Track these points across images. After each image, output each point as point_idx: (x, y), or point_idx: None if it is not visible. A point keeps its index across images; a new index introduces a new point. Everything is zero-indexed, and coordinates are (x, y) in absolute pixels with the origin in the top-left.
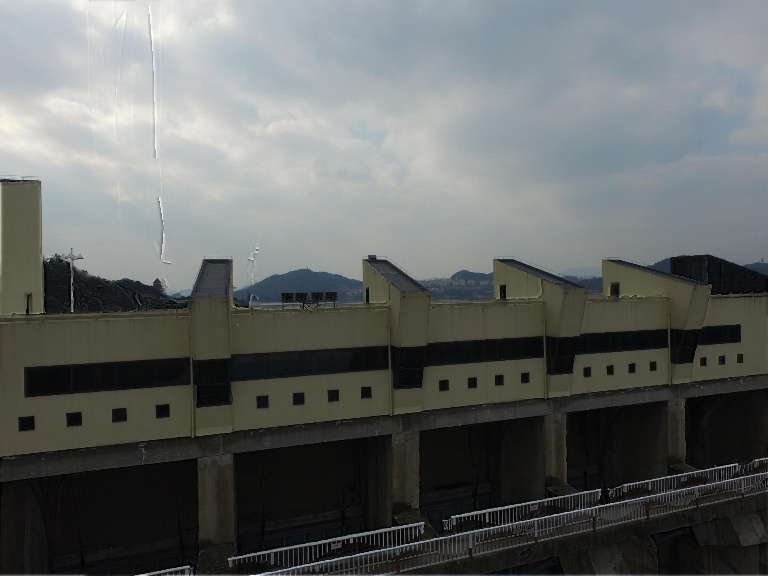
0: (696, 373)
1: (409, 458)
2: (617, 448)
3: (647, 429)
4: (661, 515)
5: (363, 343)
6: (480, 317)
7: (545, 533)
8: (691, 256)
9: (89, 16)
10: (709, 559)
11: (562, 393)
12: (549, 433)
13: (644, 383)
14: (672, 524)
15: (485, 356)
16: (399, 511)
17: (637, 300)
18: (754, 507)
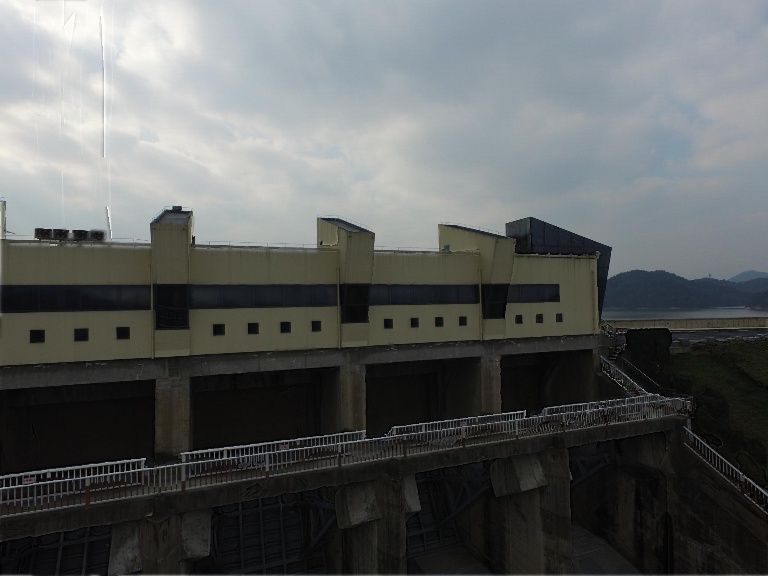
0: (511, 330)
1: (177, 405)
2: (449, 412)
3: (468, 388)
4: (421, 454)
5: (120, 281)
6: (264, 261)
7: (279, 468)
8: (519, 220)
9: (36, 15)
10: (508, 512)
11: (358, 343)
12: (345, 385)
13: (453, 338)
14: (433, 463)
15: (270, 302)
16: (163, 461)
17: (445, 254)
18: (529, 450)
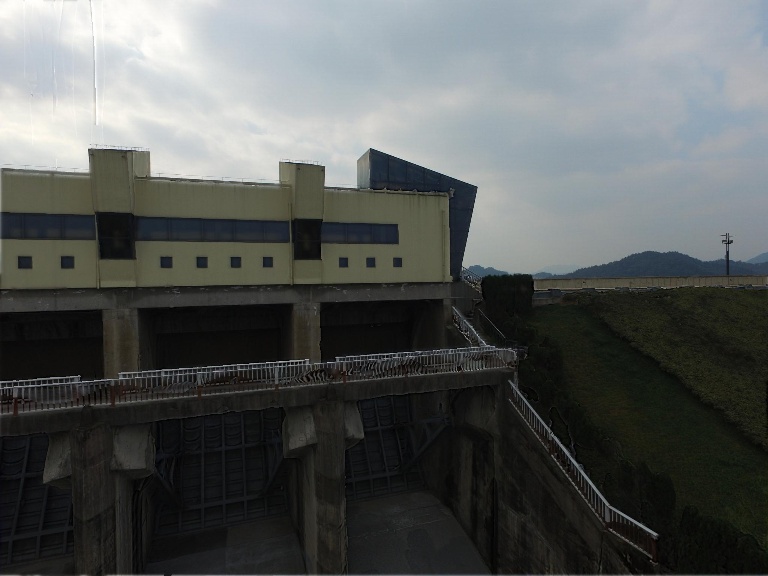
0: (333, 275)
1: None
2: None
3: (289, 341)
4: (136, 403)
5: None
6: None
7: None
8: None
9: None
10: None
11: (123, 283)
12: (110, 330)
13: (255, 281)
14: (153, 414)
15: (6, 233)
16: None
17: (244, 185)
18: (294, 402)
